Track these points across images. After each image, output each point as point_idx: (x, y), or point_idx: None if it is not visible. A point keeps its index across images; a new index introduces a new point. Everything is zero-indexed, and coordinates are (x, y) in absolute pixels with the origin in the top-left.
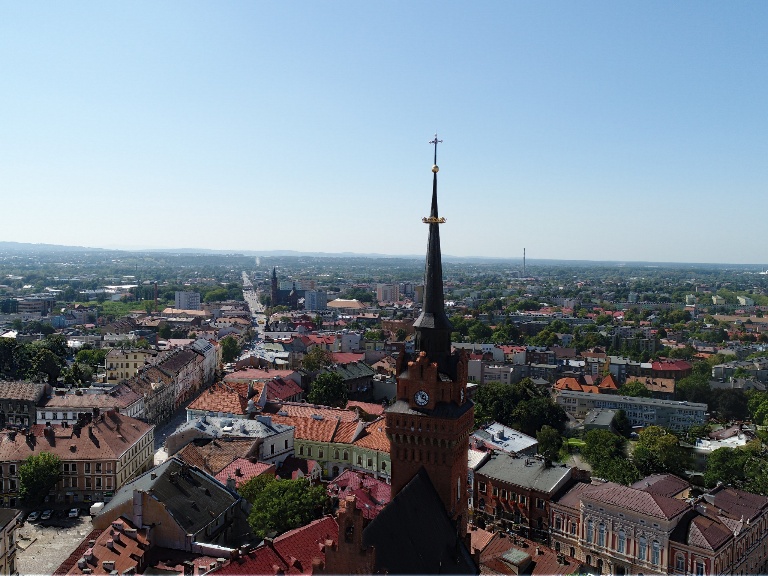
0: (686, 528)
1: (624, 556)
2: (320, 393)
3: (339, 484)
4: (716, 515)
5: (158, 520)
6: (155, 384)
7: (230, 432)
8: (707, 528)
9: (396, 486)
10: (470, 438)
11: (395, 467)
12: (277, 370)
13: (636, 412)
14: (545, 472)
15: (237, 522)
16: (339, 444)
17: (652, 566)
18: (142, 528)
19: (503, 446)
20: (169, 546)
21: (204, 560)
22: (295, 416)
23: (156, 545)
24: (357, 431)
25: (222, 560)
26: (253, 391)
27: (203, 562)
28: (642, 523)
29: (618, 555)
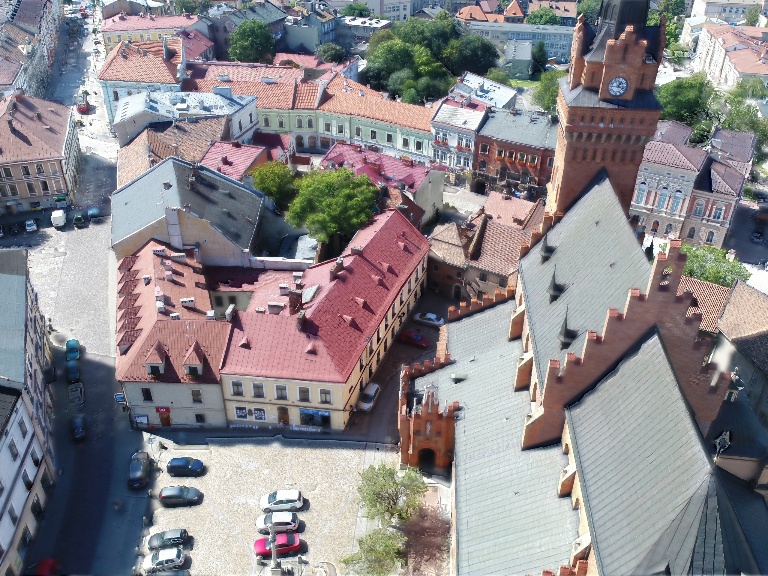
0: (707, 176)
1: (642, 207)
2: (246, 47)
3: (336, 161)
4: (725, 159)
5: (202, 238)
6: (24, 47)
7: (187, 110)
8: (725, 174)
9: (567, 191)
10: (454, 94)
11: (569, 170)
12: (164, 17)
13: (553, 43)
14: (553, 129)
15: (262, 221)
16: (302, 111)
17: (670, 214)
18: (183, 249)
19: (488, 100)
20: (221, 264)
21: (271, 275)
22: (240, 81)
23: (204, 265)
24: (319, 94)
25: (300, 274)
26: (169, 51)
27: (271, 277)
28: (668, 175)
29: (636, 206)
